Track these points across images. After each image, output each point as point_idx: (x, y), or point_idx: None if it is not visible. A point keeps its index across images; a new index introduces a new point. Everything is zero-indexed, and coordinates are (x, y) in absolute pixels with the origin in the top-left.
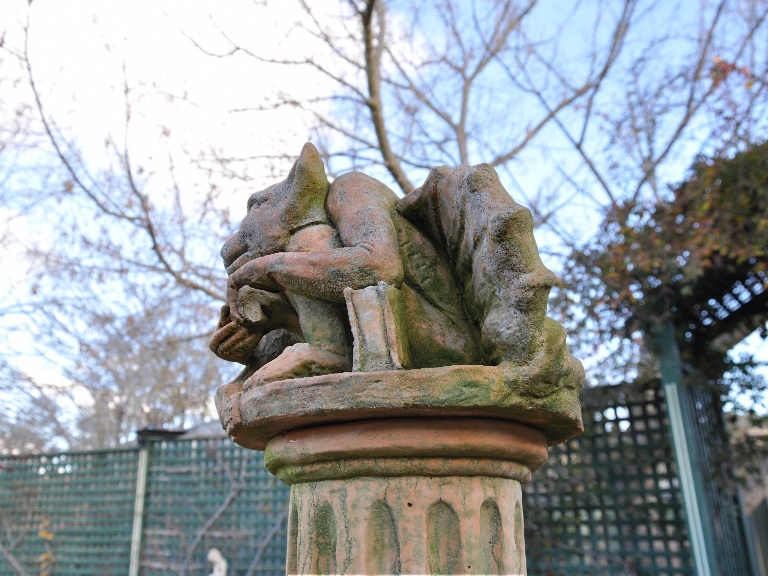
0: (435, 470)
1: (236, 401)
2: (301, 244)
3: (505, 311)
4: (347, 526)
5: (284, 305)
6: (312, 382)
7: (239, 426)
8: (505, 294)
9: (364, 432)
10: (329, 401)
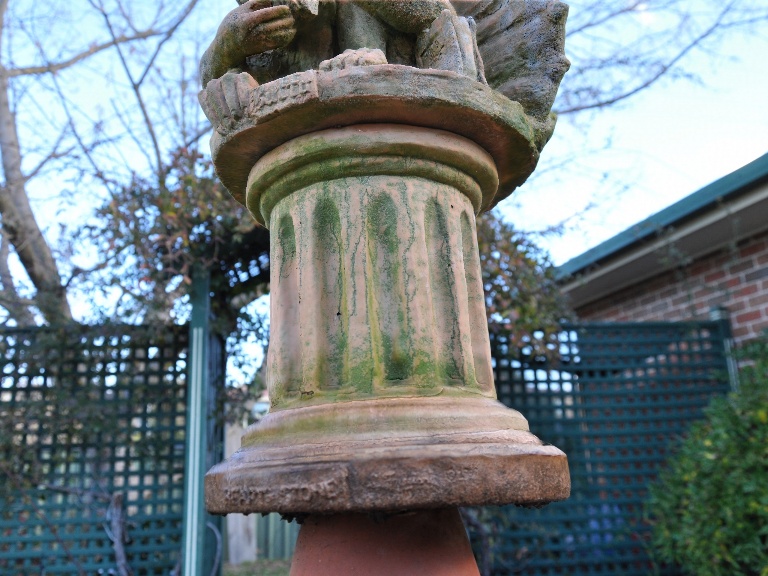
0: (468, 185)
1: (315, 76)
2: None
3: (540, 78)
4: (409, 212)
5: (331, 13)
6: (431, 72)
7: (313, 102)
8: (543, 65)
9: (440, 135)
10: (443, 93)
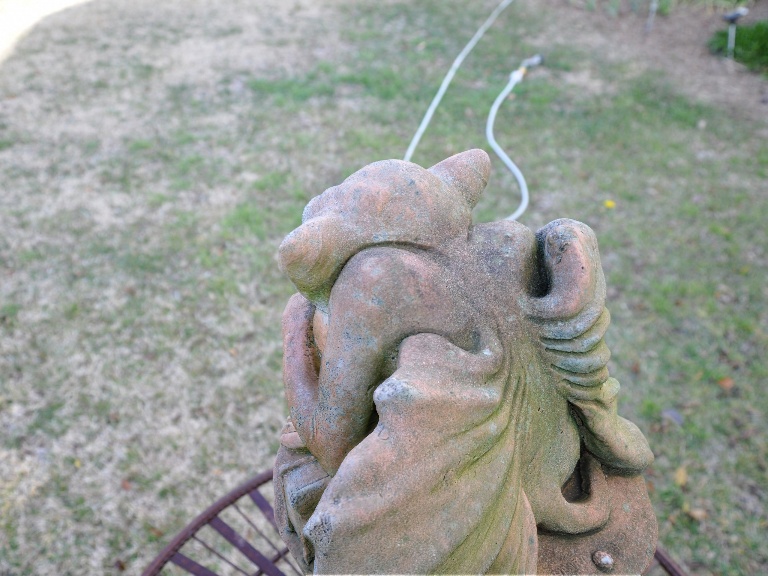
0: None
1: None
2: (313, 330)
3: None
4: None
5: None
6: None
7: None
8: None
9: None
10: None
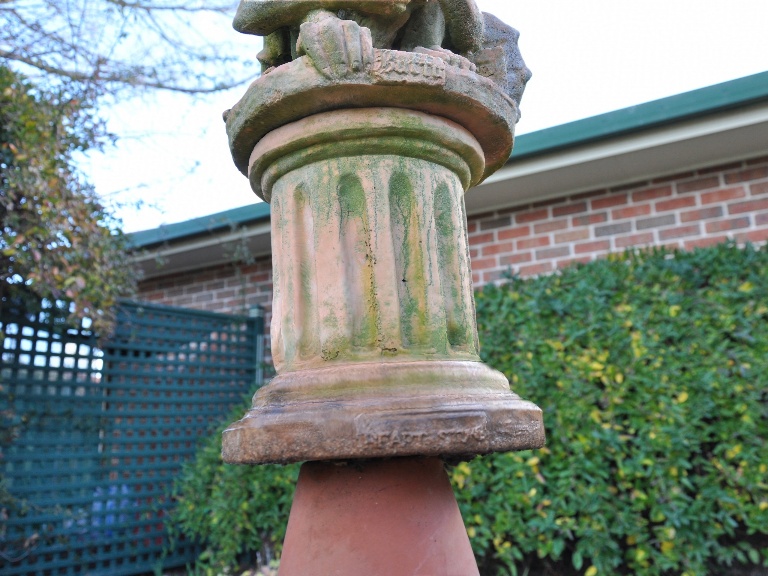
0: None
1: None
2: None
3: None
4: None
5: None
6: None
7: (439, 87)
8: None
9: None
10: None
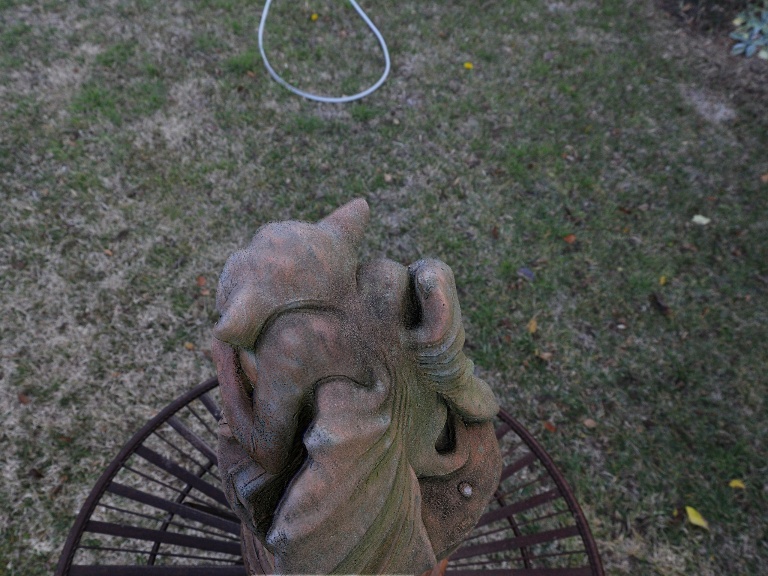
0: None
1: None
2: (240, 361)
3: None
4: None
5: None
6: None
7: None
8: None
9: None
10: None
